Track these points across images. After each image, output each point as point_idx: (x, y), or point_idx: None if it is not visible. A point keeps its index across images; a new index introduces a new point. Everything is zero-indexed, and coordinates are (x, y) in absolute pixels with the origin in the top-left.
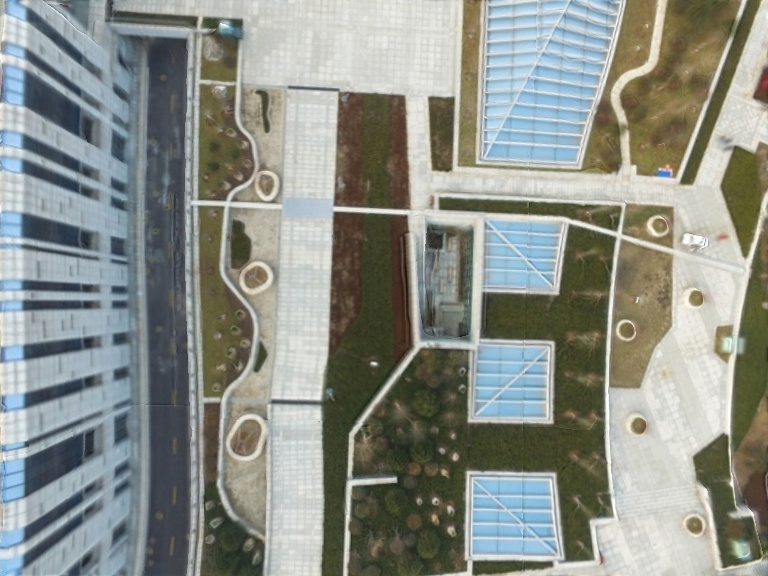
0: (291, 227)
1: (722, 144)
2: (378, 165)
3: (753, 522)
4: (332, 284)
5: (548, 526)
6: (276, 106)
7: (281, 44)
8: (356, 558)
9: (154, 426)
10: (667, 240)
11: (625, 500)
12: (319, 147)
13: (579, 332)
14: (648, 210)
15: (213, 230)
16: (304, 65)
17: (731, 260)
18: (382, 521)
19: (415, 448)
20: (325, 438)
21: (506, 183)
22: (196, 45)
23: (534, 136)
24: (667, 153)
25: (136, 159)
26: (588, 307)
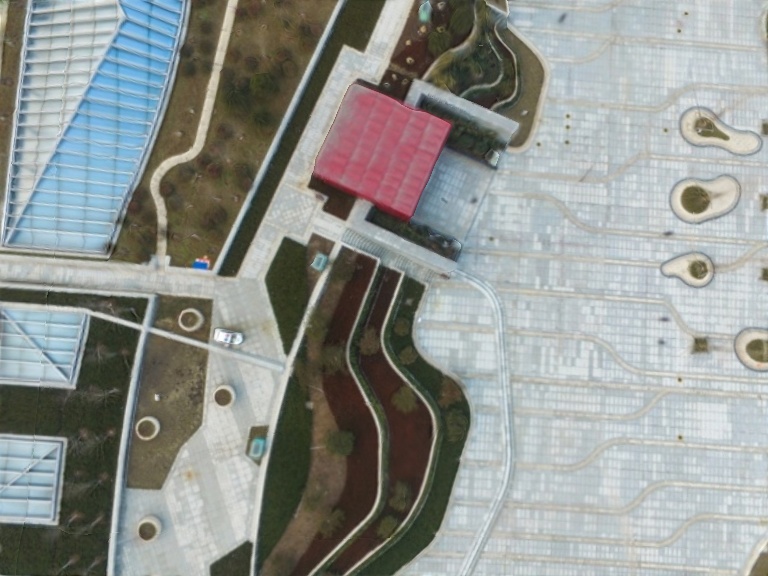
0: None
1: (271, 235)
2: None
3: None
4: None
5: None
6: None
7: None
8: None
9: None
10: (202, 334)
11: None
12: None
13: (88, 430)
14: (184, 302)
15: None
16: None
17: (272, 357)
18: None
19: None
20: None
21: (33, 270)
22: None
23: (58, 223)
24: (204, 244)
25: None
26: (97, 404)
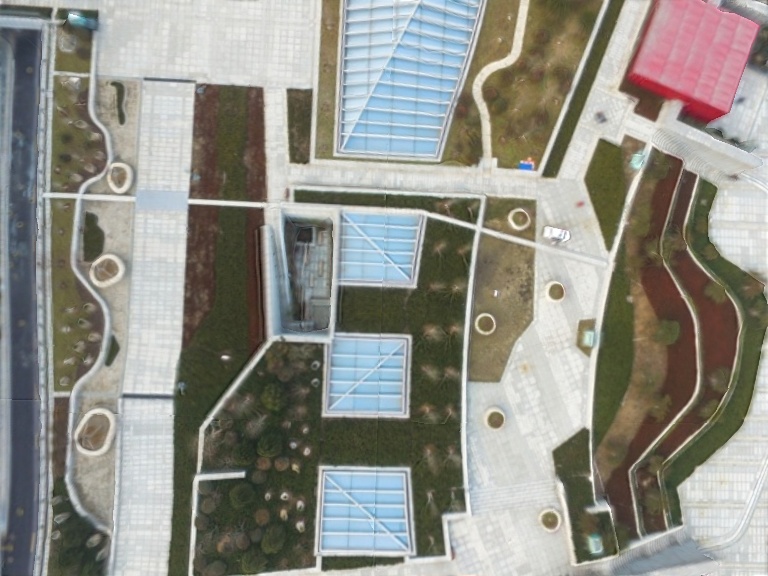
0: (145, 220)
1: (587, 137)
2: (234, 157)
3: (609, 517)
4: (186, 277)
5: (400, 521)
6: (132, 98)
7: (137, 35)
8: (200, 554)
9: (16, 421)
10: (529, 233)
11: (481, 495)
12: (175, 139)
13: (435, 325)
14: (510, 203)
15: (64, 222)
16: (160, 57)
17: (594, 253)
18: (229, 516)
19: (260, 442)
20: (176, 433)
21: (365, 176)
22: (50, 36)
23: (392, 128)
24: (528, 146)
25: (0, 152)
26: (444, 300)
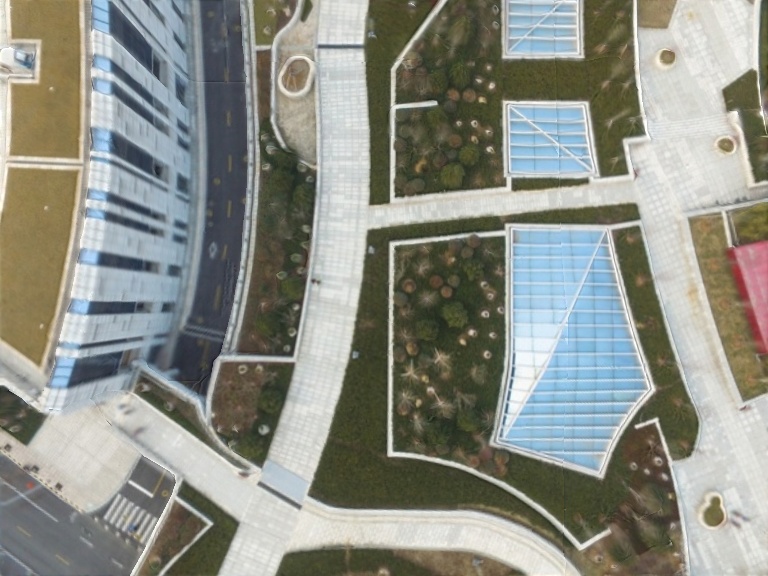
0: None
1: None
2: None
3: None
4: None
5: (582, 146)
6: None
7: None
8: (402, 170)
9: (209, 101)
10: None
11: (657, 127)
12: None
13: None
14: None
15: None
16: None
17: None
18: (425, 140)
19: (454, 67)
20: (369, 77)
21: None
22: None
23: None
24: None
25: None
26: None
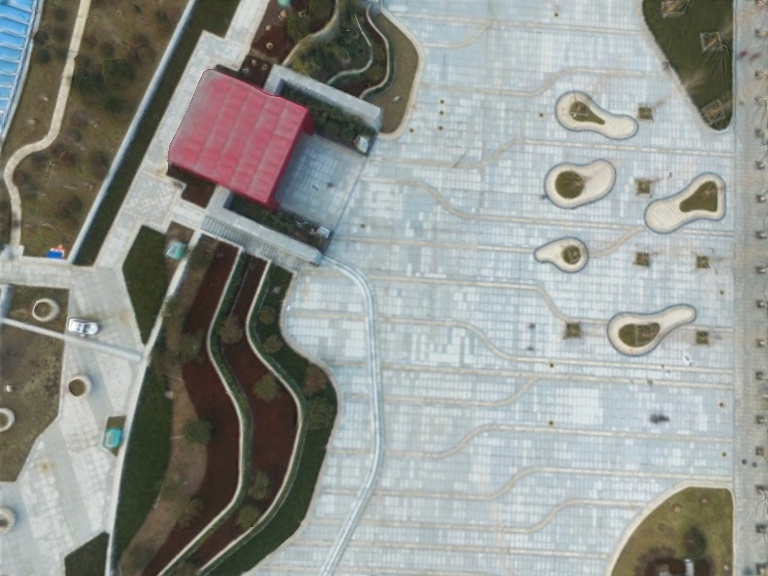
0: None
1: (129, 223)
2: None
3: None
4: None
5: None
6: None
7: None
8: None
9: None
10: (58, 324)
11: None
12: None
13: None
14: (40, 292)
15: None
16: None
17: (129, 346)
18: None
19: None
20: None
21: None
22: None
23: None
24: (58, 233)
25: None
26: None
